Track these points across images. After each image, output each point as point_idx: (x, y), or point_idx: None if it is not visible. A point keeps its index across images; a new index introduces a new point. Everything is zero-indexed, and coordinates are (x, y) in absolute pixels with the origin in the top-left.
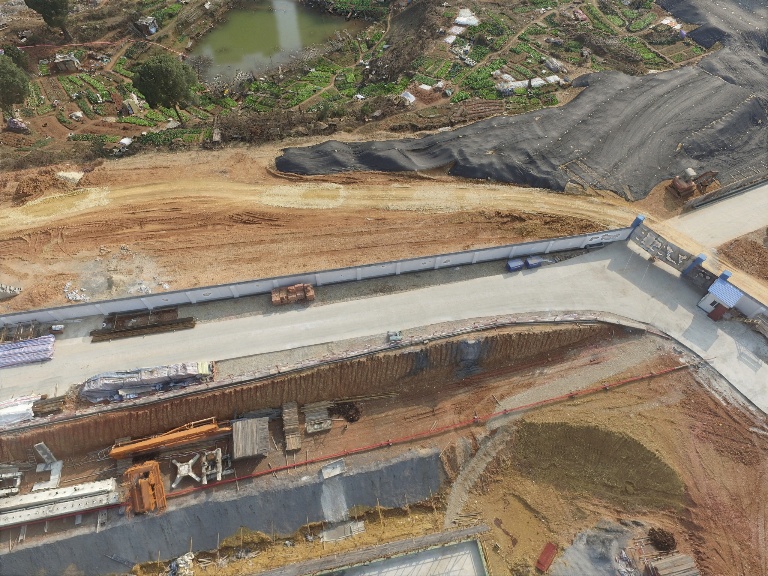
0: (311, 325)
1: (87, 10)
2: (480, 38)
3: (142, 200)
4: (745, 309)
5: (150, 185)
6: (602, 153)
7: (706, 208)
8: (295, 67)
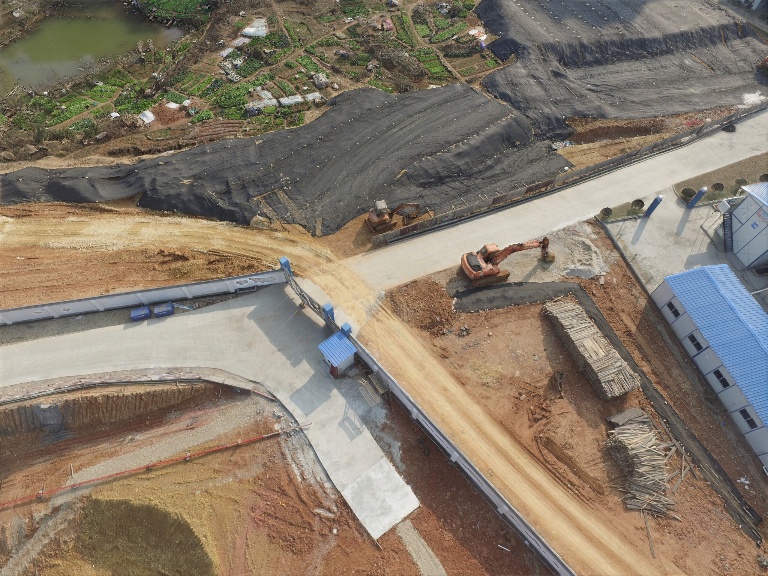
0: None
1: None
2: (255, 51)
3: None
4: None
5: None
6: (312, 181)
7: (401, 244)
8: (76, 81)
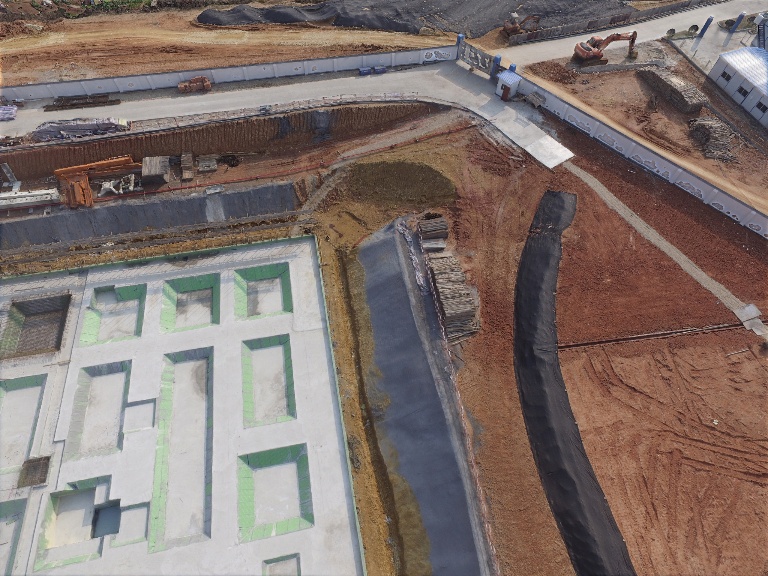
0: (206, 103)
1: None
2: None
3: (91, 40)
4: (528, 93)
5: (98, 32)
6: (456, 11)
7: (528, 45)
8: None
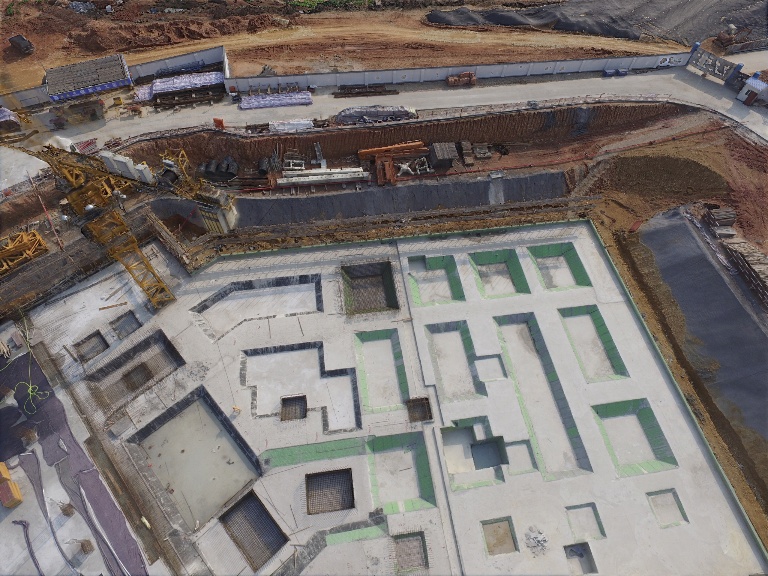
0: (476, 96)
1: None
2: None
3: (337, 34)
4: None
5: (339, 27)
6: (665, 20)
7: (742, 54)
8: None
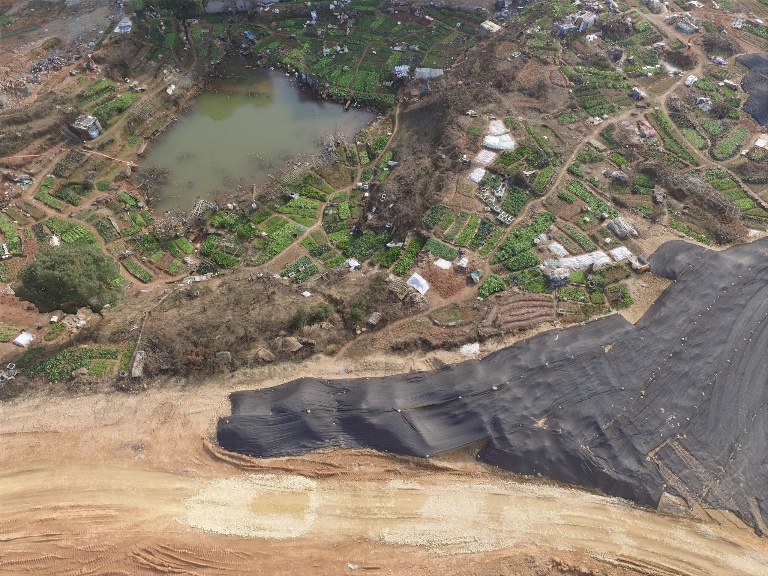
0: None
1: (8, 110)
2: (518, 177)
3: (5, 510)
4: None
5: (24, 473)
6: (709, 423)
7: None
8: (272, 195)
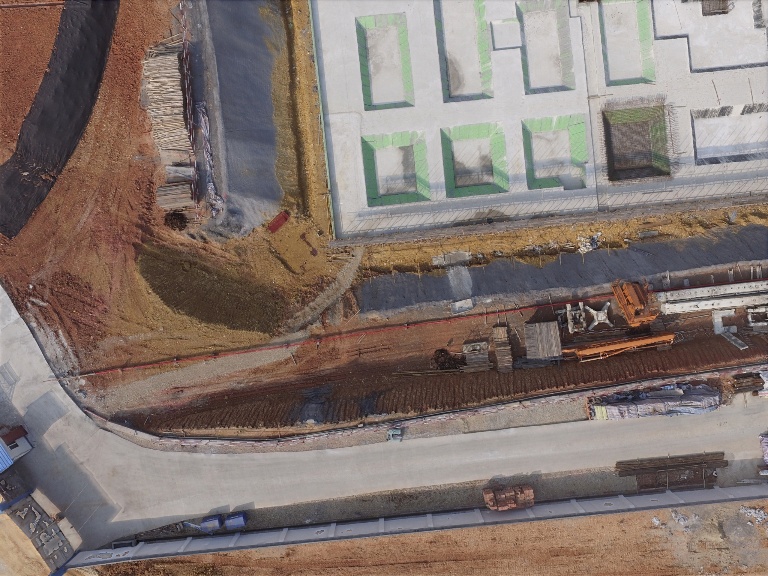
0: (487, 456)
1: None
2: None
3: None
4: None
5: None
6: None
7: None
8: None
